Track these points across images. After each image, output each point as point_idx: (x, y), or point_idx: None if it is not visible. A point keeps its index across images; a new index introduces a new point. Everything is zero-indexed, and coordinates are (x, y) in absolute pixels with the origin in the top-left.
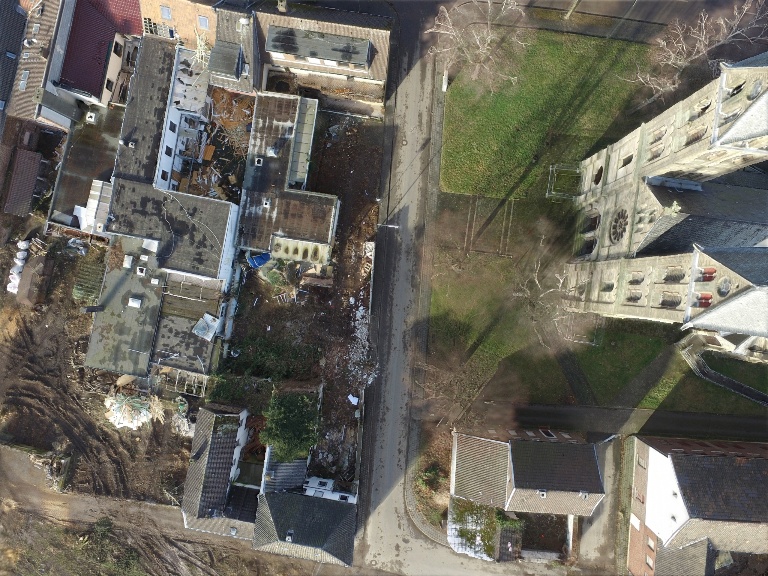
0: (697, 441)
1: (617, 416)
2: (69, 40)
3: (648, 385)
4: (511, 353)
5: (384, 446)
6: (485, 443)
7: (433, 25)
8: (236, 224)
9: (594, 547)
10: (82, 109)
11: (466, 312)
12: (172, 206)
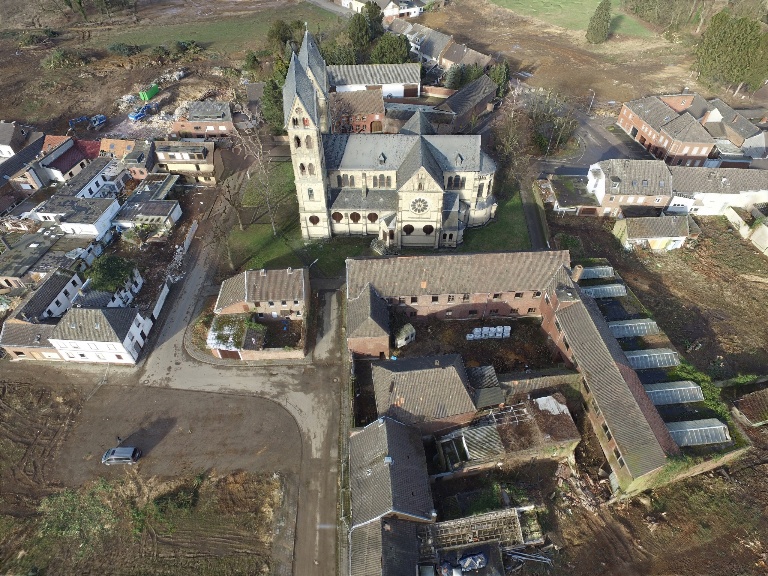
0: None
1: (339, 281)
2: (59, 157)
3: None
4: (272, 259)
5: (177, 311)
6: (239, 276)
7: (247, 163)
8: (116, 213)
9: (325, 351)
10: (51, 183)
11: (246, 245)
12: (81, 202)
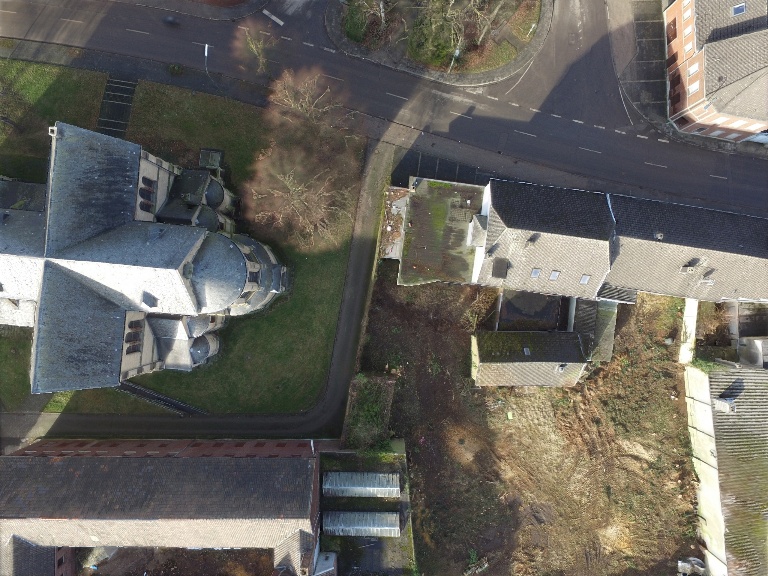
0: (89, 441)
1: (25, 421)
2: None
3: None
4: None
5: None
6: None
7: None
8: None
9: None
10: None
11: None
12: None
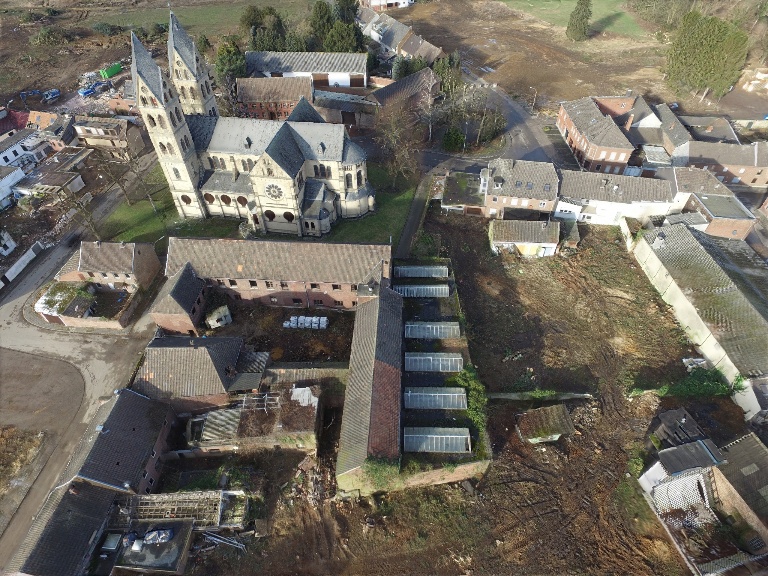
0: None
1: None
2: None
3: None
4: (142, 234)
5: (34, 275)
6: None
7: None
8: (19, 180)
9: (145, 324)
10: None
11: (126, 219)
12: None
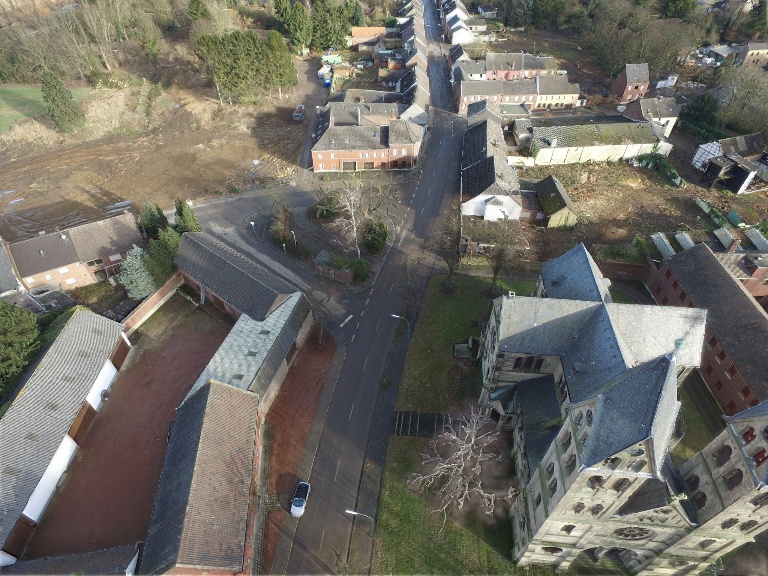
0: None
1: None
2: None
3: None
4: None
5: None
6: None
7: None
8: None
9: None
10: None
11: None
12: None
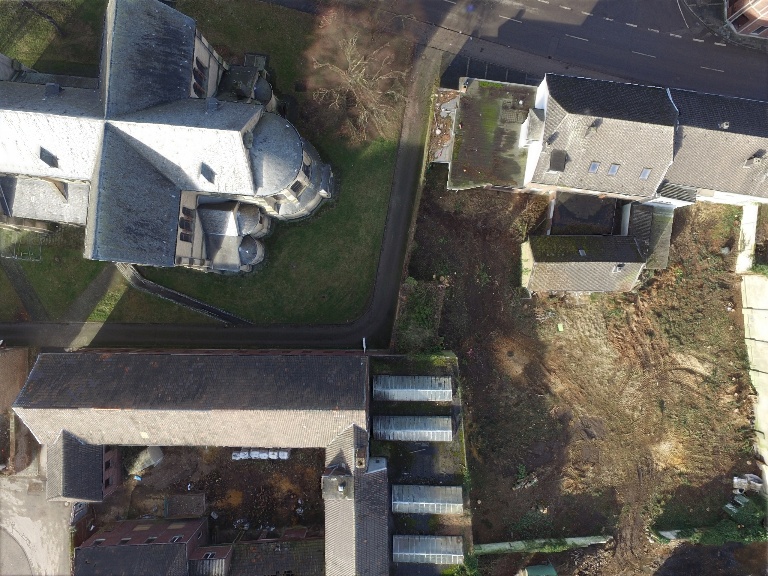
0: (133, 349)
1: (69, 330)
2: None
3: (96, 299)
4: None
5: None
6: None
7: None
8: None
9: None
10: None
11: None
12: None
